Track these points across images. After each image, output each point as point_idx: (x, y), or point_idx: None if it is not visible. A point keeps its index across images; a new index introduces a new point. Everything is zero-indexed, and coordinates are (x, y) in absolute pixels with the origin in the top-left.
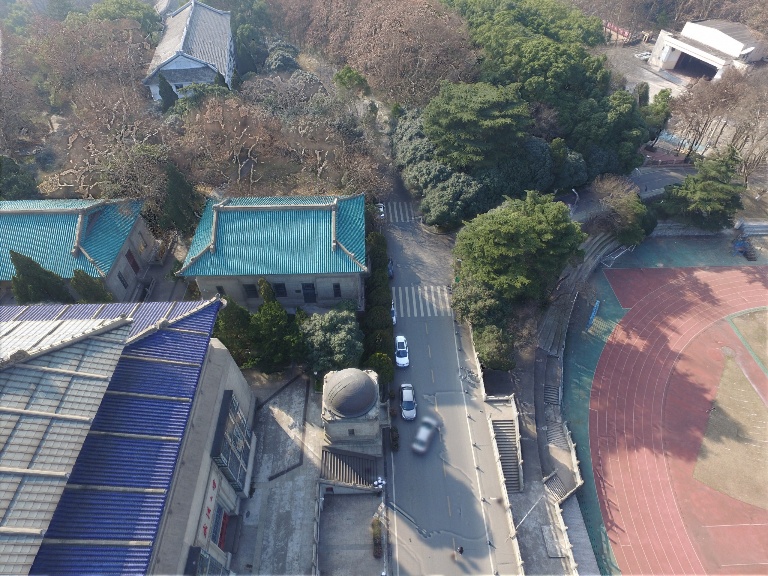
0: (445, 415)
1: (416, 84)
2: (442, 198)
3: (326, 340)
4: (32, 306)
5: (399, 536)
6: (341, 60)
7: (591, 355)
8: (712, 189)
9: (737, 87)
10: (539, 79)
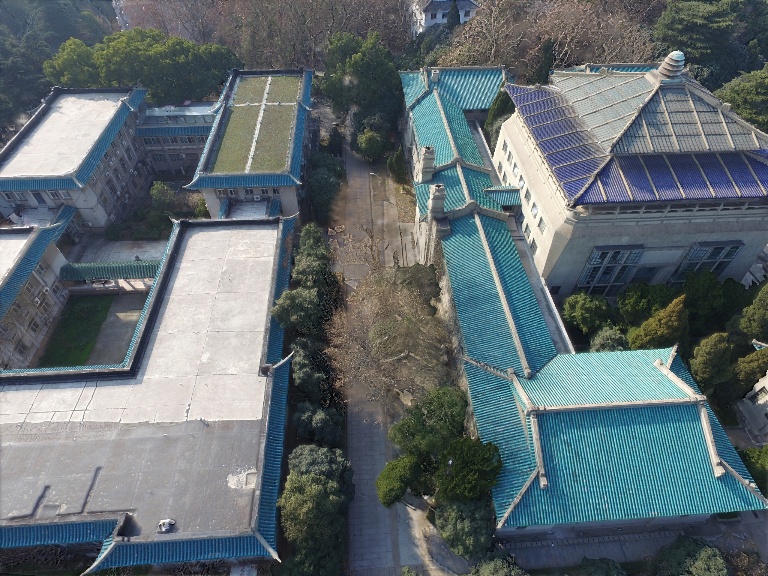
0: None
1: (633, 8)
2: None
3: None
4: None
5: None
6: None
7: None
8: None
9: None
10: None
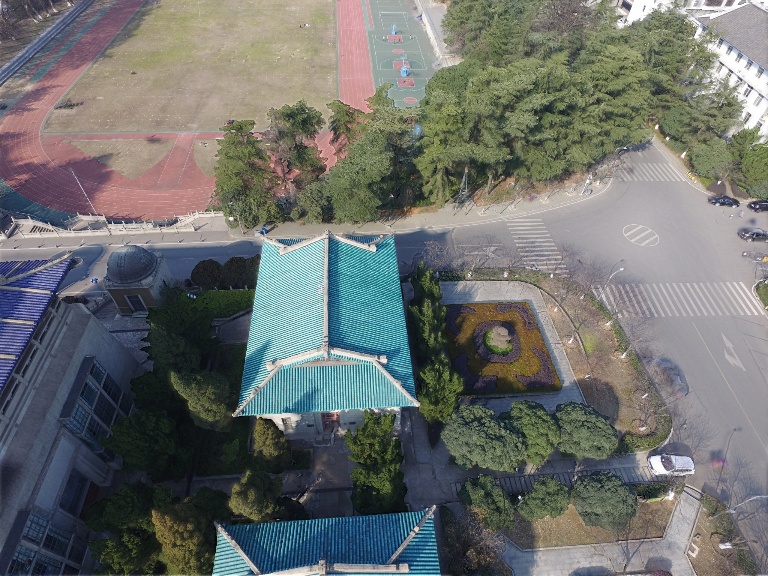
0: None
1: None
2: None
3: None
4: None
5: (80, 291)
6: None
7: (20, 201)
8: None
9: None
10: None
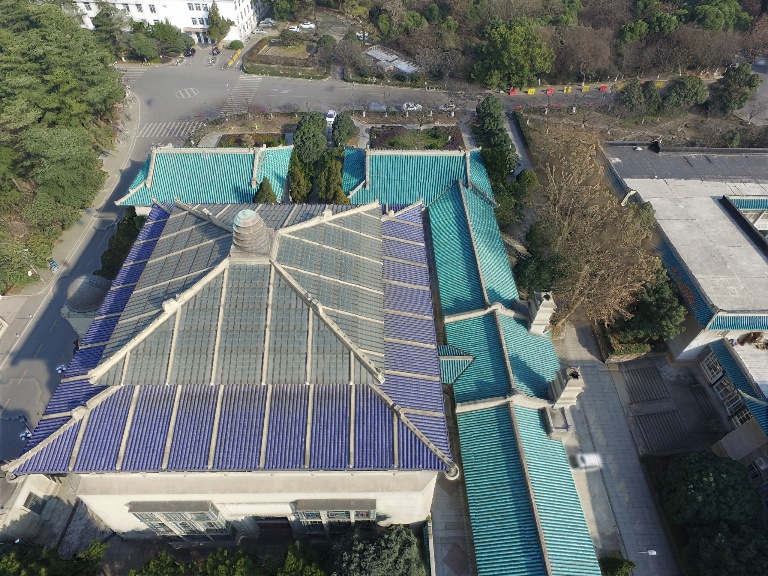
0: None
1: None
2: None
3: None
4: (258, 467)
5: None
6: None
7: None
8: None
9: None
10: None
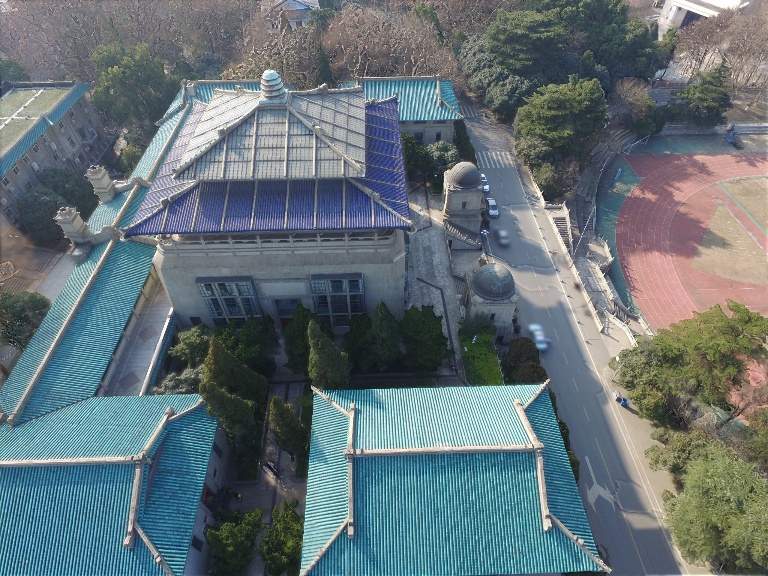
0: (518, 215)
1: (475, 17)
2: (503, 91)
3: (442, 155)
4: None
5: None
6: (403, 11)
7: (616, 203)
8: (708, 91)
9: (729, 20)
10: (573, 8)
